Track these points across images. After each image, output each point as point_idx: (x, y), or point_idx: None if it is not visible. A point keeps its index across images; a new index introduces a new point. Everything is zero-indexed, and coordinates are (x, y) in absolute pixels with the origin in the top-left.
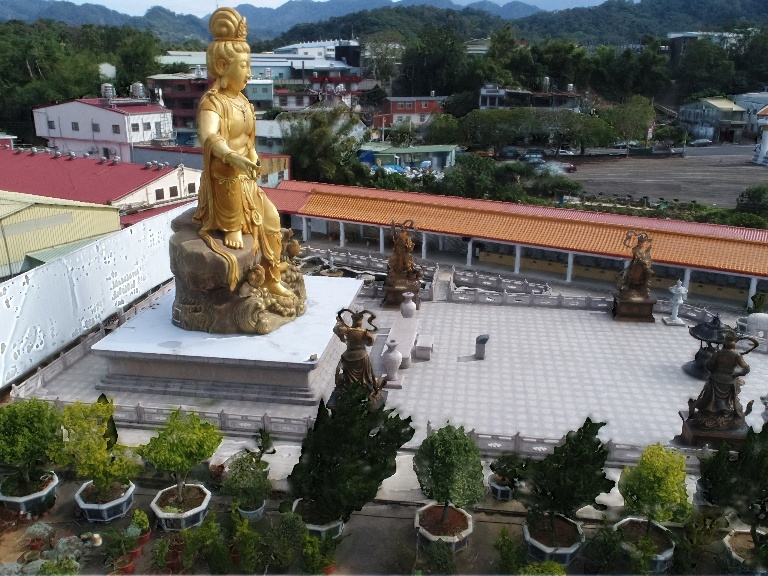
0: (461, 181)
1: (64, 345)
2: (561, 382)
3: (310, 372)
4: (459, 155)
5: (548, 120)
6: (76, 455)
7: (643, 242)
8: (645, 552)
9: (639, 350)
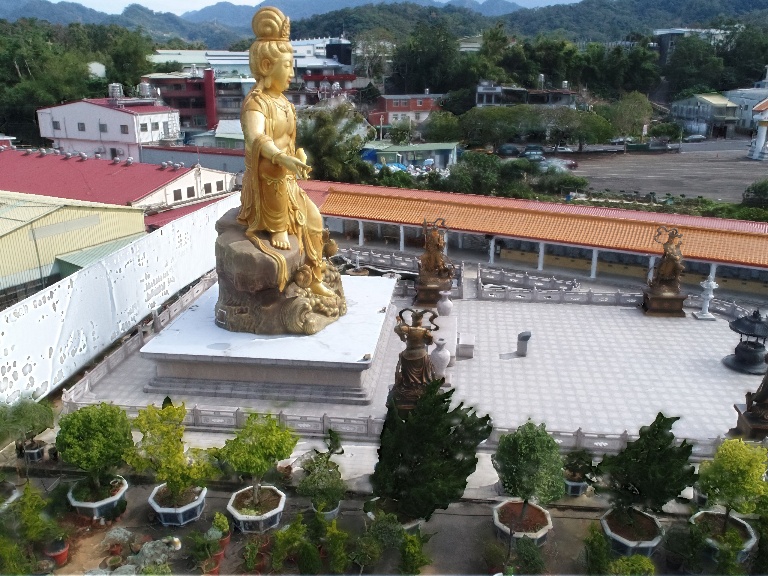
0: (468, 179)
1: (104, 348)
2: (607, 378)
3: (362, 372)
4: (464, 153)
5: (548, 117)
6: (153, 459)
7: (674, 238)
8: (733, 544)
9: (676, 345)
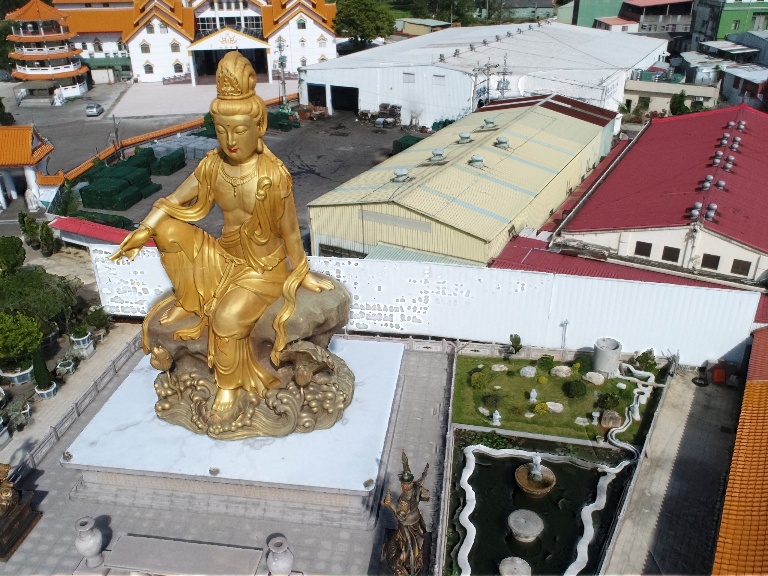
0: None
1: None
2: None
3: (89, 471)
4: None
5: None
6: None
7: None
8: None
9: None
